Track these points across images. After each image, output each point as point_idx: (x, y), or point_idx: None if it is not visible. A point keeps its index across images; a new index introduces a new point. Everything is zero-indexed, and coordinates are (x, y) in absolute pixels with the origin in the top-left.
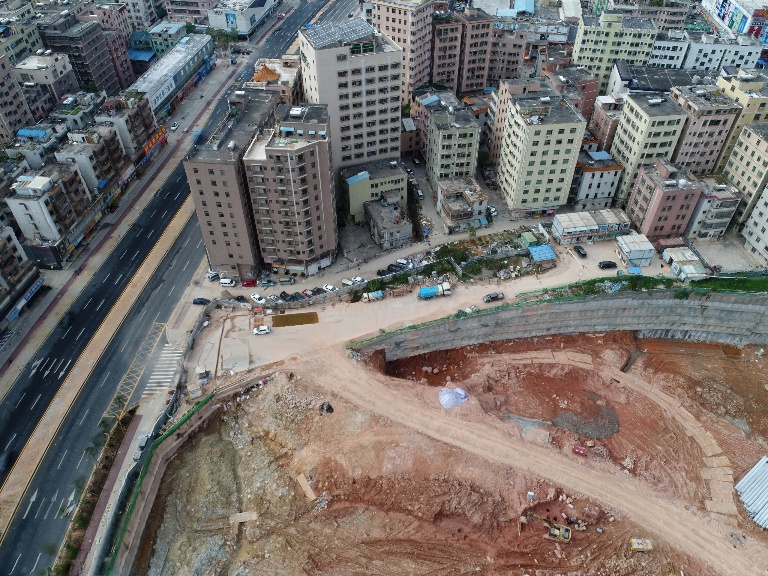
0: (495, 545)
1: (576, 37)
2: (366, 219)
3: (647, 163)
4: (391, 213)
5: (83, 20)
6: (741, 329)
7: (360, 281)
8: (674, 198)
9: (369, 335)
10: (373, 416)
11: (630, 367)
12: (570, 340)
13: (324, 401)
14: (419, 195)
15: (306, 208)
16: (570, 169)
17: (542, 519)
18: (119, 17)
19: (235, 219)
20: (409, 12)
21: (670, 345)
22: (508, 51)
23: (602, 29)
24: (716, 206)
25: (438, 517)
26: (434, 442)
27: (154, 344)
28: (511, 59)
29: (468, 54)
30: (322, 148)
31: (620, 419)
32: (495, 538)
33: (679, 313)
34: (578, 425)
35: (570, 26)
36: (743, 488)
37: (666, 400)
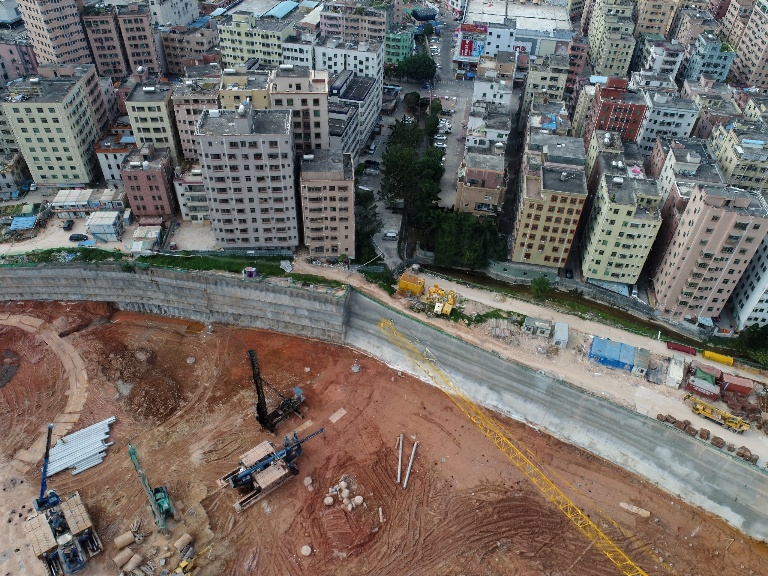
0: None
1: None
2: None
3: None
4: None
5: None
6: (201, 306)
7: None
8: (136, 178)
9: None
10: None
11: None
12: (39, 306)
13: None
14: None
15: None
16: (72, 148)
17: None
18: None
19: None
20: (36, 2)
21: (144, 318)
22: (193, 48)
23: (233, 29)
24: (185, 189)
25: None
26: None
27: None
28: None
29: (129, 47)
30: None
31: (16, 376)
32: None
33: (139, 287)
34: None
35: (298, 31)
36: None
37: (75, 363)
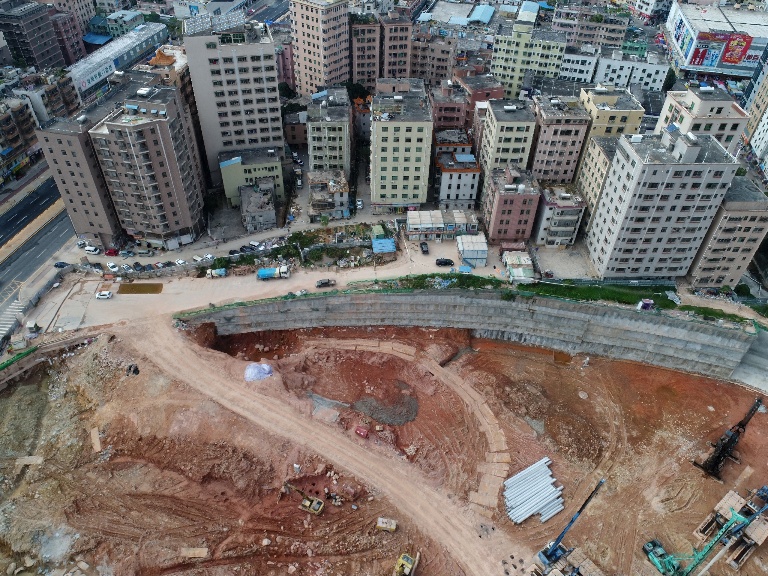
0: (251, 510)
1: None
2: None
3: (502, 168)
4: (260, 198)
5: (40, 2)
6: (572, 336)
7: (210, 258)
8: (512, 202)
9: (200, 308)
10: (174, 381)
11: (450, 362)
12: (402, 332)
13: (133, 363)
14: (297, 184)
15: (153, 183)
16: (424, 168)
17: (295, 489)
18: (80, 2)
19: (89, 189)
20: (319, 10)
21: (504, 347)
22: (437, 56)
23: (512, 39)
24: (557, 214)
25: (207, 479)
26: (223, 410)
27: (5, 299)
28: (440, 64)
29: (388, 56)
30: (163, 127)
31: (420, 409)
32: (253, 504)
33: (510, 315)
34: (375, 410)
35: None
36: (511, 484)
37: (472, 396)
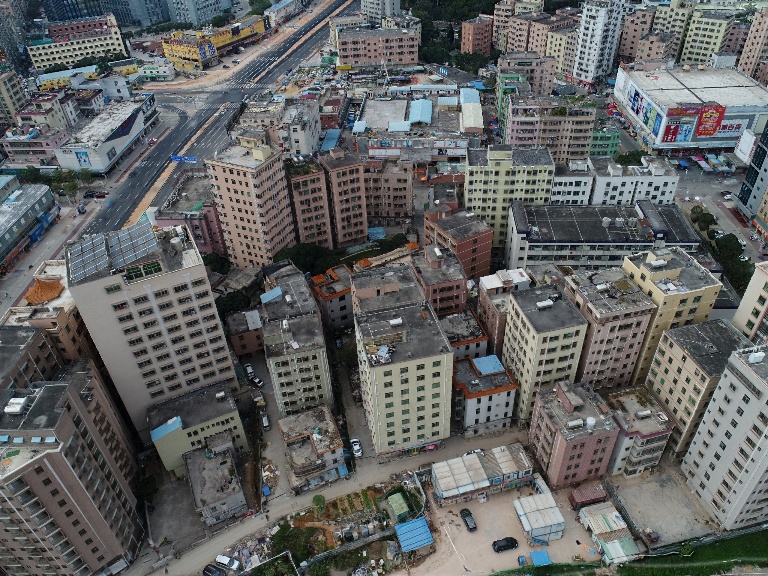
0: None
1: None
2: None
3: (546, 380)
4: (217, 470)
5: None
6: None
7: None
8: (583, 445)
9: None
10: None
11: None
12: None
13: None
14: (263, 426)
15: (53, 532)
16: (444, 402)
17: None
18: None
19: None
20: (248, 173)
21: None
22: (392, 186)
23: (490, 168)
24: (641, 444)
25: None
26: None
27: None
28: (397, 194)
29: (338, 203)
30: (56, 458)
31: None
32: None
33: None
34: None
35: (469, 139)
36: None
37: None
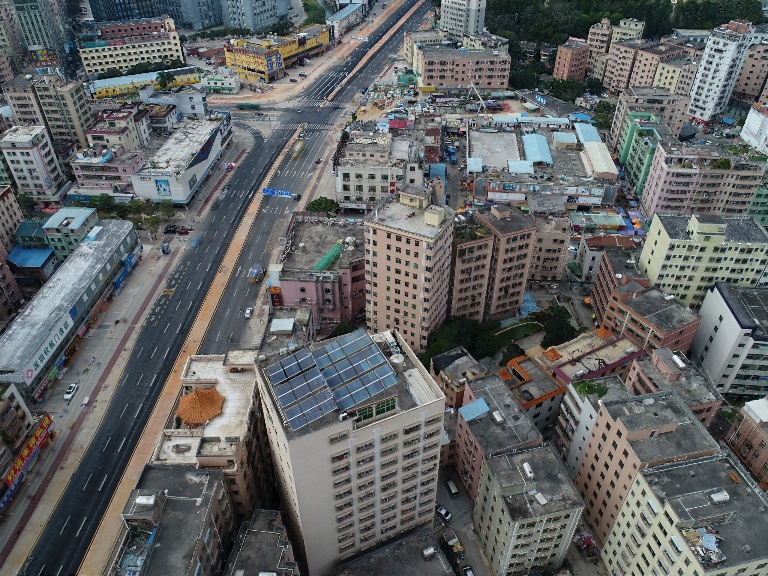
0: None
1: (647, 240)
2: None
3: None
4: None
5: None
6: None
7: None
8: None
9: None
10: None
11: None
12: None
13: None
14: None
15: None
16: None
17: None
18: None
19: None
20: (423, 243)
21: None
22: (545, 247)
23: (696, 243)
24: None
25: None
26: None
27: None
28: (549, 256)
29: (500, 271)
30: None
31: None
32: None
33: None
34: None
35: (605, 186)
36: None
37: None
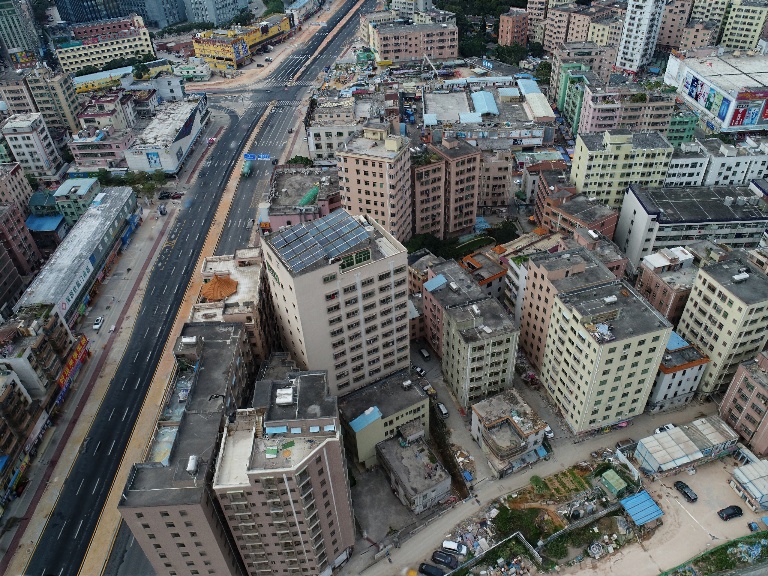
0: None
1: (574, 158)
2: (381, 464)
3: (740, 352)
4: (416, 458)
5: None
6: None
7: None
8: None
9: None
10: None
11: None
12: None
13: None
14: (443, 413)
15: (314, 524)
16: (650, 378)
17: None
18: (12, 181)
19: (208, 556)
20: (385, 164)
21: None
22: (492, 175)
23: (610, 152)
24: None
25: None
26: None
27: None
28: (497, 183)
29: (454, 192)
30: (332, 447)
31: None
32: None
33: None
34: None
35: (544, 128)
36: None
37: None
